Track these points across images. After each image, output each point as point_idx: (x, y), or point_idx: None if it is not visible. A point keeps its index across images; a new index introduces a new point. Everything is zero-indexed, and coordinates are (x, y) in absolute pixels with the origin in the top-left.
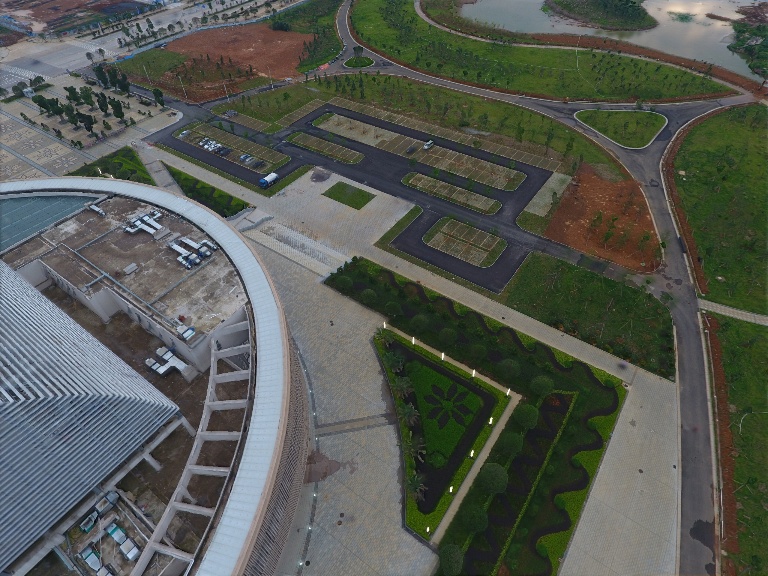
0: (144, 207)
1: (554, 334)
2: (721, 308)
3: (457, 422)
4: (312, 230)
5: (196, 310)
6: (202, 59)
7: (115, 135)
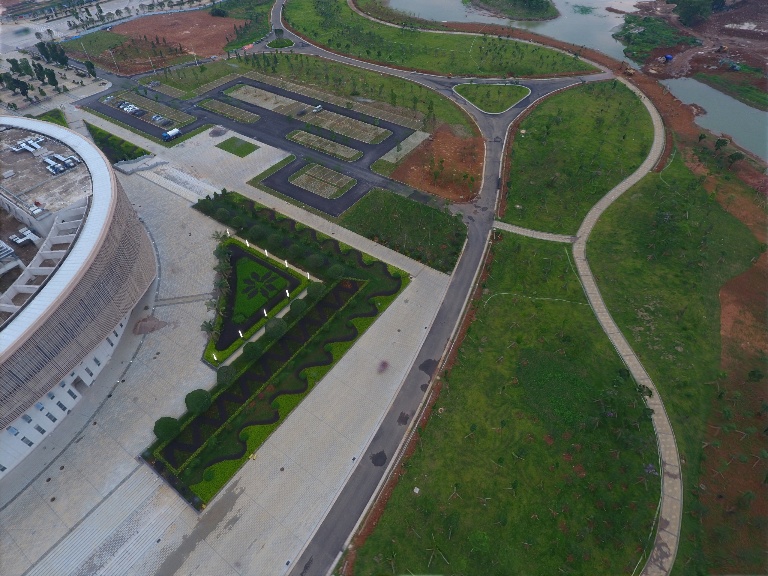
0: (33, 136)
1: (369, 244)
2: (510, 227)
3: (263, 295)
4: (198, 172)
5: (51, 200)
6: (141, 39)
7: (48, 100)
